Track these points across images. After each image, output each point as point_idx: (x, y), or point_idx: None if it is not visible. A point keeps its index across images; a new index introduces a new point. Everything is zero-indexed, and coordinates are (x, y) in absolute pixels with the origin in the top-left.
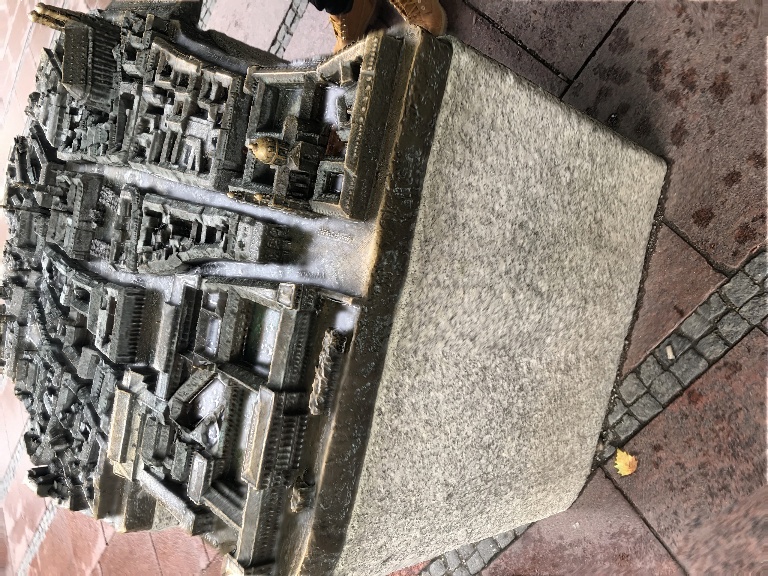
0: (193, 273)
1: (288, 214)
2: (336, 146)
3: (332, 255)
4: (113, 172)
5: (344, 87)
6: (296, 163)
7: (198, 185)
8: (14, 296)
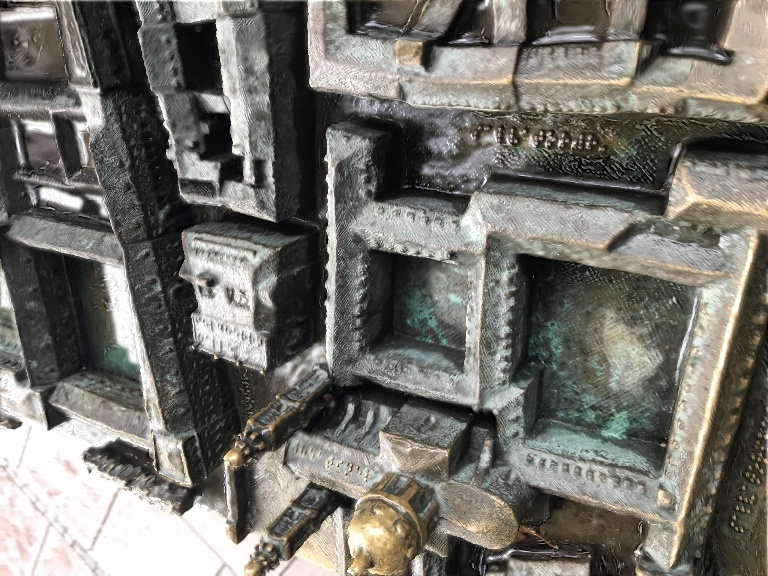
0: (91, 39)
1: None
2: None
3: None
4: None
5: None
6: None
7: None
8: None
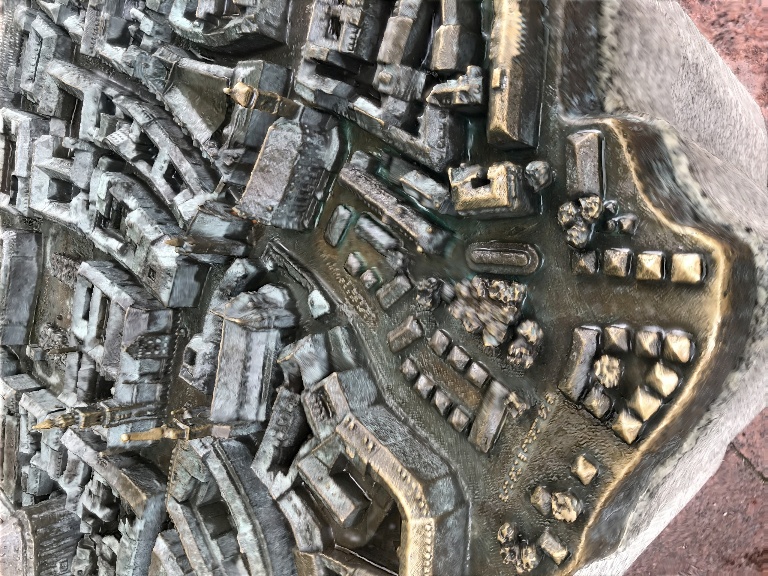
0: None
1: None
2: None
3: None
4: None
5: None
6: None
7: None
8: (251, 177)
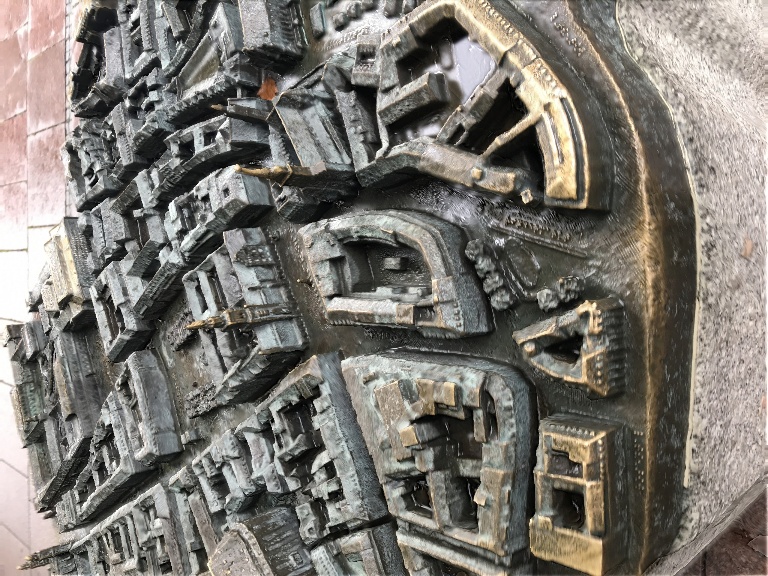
0: None
1: None
2: None
3: None
4: (239, 423)
5: None
6: None
7: (100, 524)
8: None
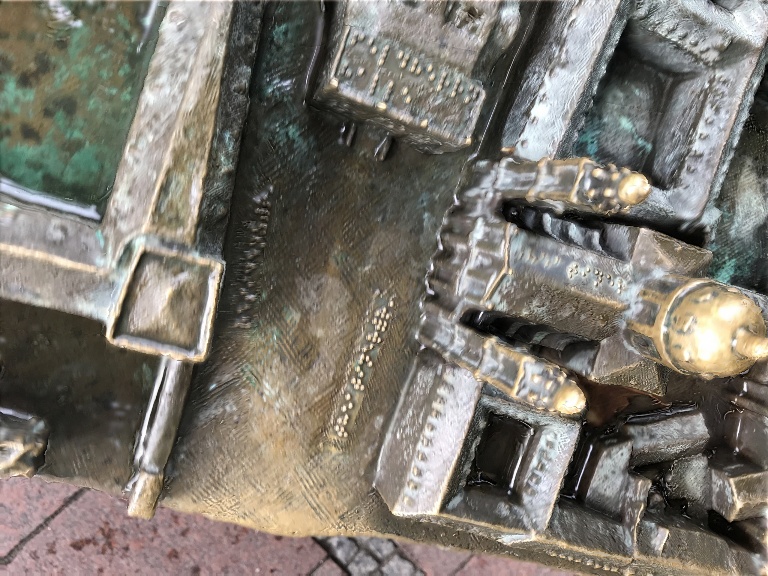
0: None
1: (472, 159)
2: (597, 390)
3: (304, 361)
4: None
5: (724, 479)
6: (612, 377)
7: None
8: None
